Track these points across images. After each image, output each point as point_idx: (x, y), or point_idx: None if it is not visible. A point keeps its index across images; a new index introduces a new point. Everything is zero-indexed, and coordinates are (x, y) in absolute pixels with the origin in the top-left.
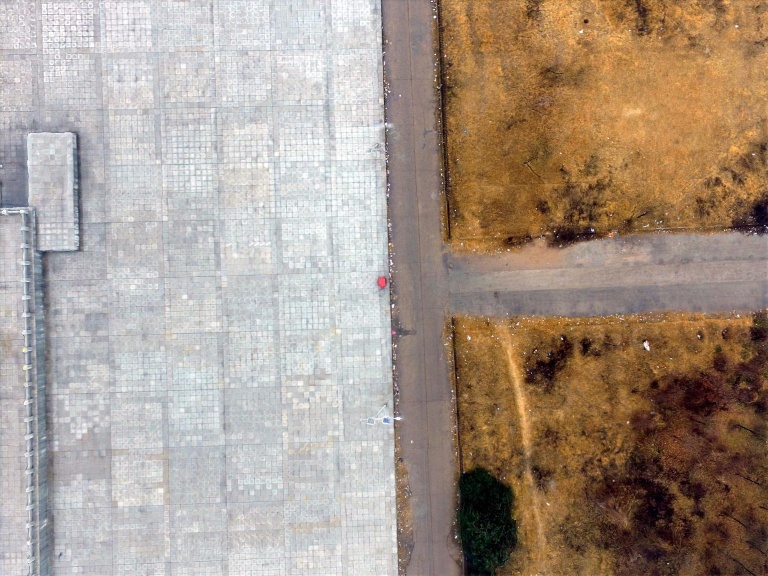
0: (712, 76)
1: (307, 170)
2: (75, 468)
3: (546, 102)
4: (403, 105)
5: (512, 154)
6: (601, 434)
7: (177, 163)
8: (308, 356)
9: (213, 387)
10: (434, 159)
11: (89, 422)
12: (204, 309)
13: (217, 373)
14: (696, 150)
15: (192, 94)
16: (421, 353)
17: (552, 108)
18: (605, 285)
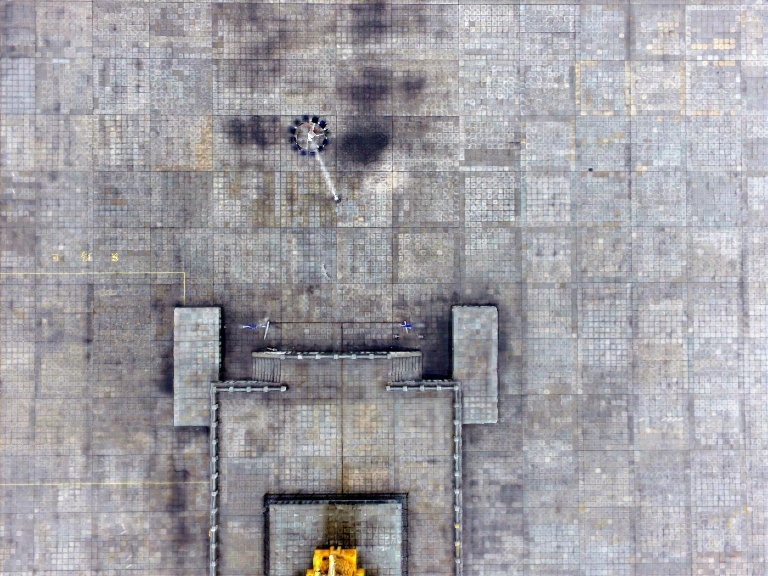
0: None
1: (720, 346)
2: None
3: None
4: None
5: None
6: None
7: (593, 337)
8: (719, 533)
9: (625, 561)
10: None
11: None
12: (617, 483)
13: (629, 548)
14: None
15: (609, 269)
16: None
17: None
18: None
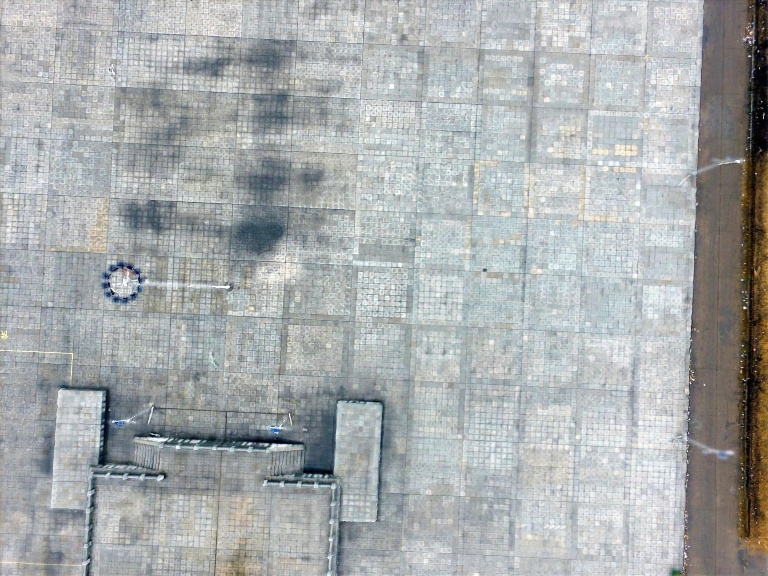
0: None
1: (607, 455)
2: None
3: None
4: (707, 395)
5: None
6: None
7: (478, 439)
8: None
9: None
10: (735, 452)
11: None
12: None
13: None
14: None
15: (498, 371)
16: None
17: None
18: None
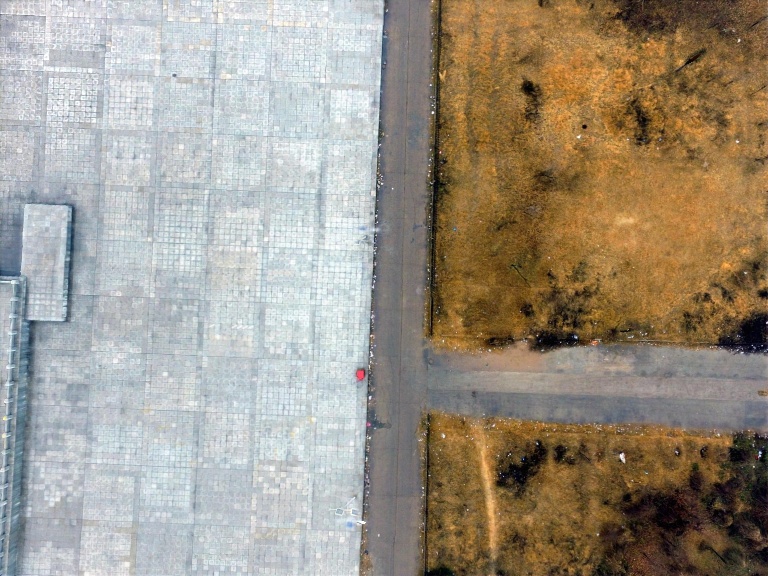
0: (708, 191)
1: (295, 257)
2: (46, 535)
3: (538, 206)
4: (395, 198)
5: (500, 255)
6: (570, 544)
7: (168, 241)
8: (282, 442)
9: (186, 465)
10: (422, 254)
11: (63, 491)
12: (183, 387)
13: (191, 452)
14: (687, 264)
15: (187, 175)
16: (395, 447)
17: (543, 212)
18: (585, 393)
